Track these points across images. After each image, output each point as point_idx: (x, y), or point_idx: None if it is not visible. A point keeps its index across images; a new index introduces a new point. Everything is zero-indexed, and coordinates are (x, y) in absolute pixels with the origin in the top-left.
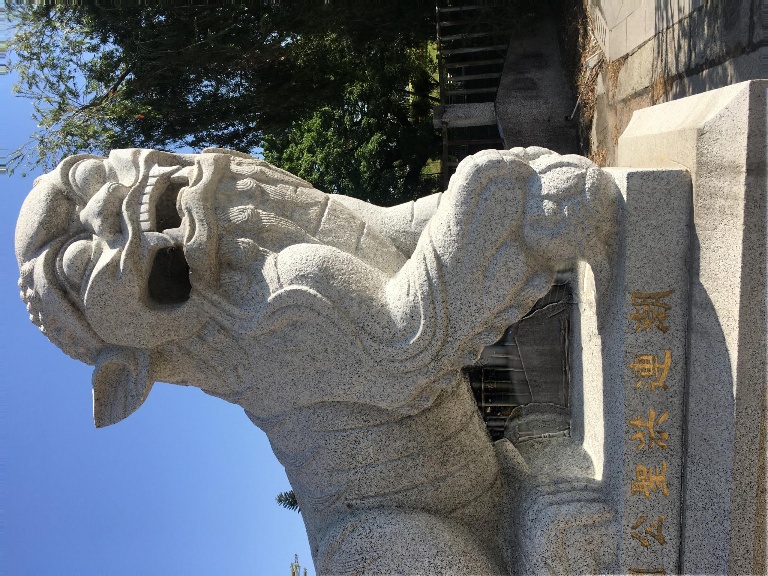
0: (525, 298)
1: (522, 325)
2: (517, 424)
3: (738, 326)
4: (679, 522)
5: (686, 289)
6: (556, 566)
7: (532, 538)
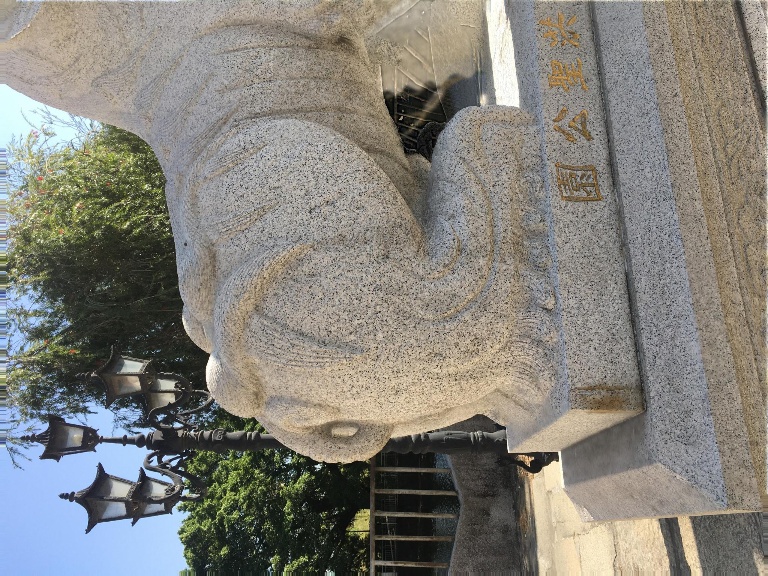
0: None
1: (434, 8)
2: (431, 139)
3: None
4: (603, 117)
5: None
6: (473, 159)
7: (445, 139)
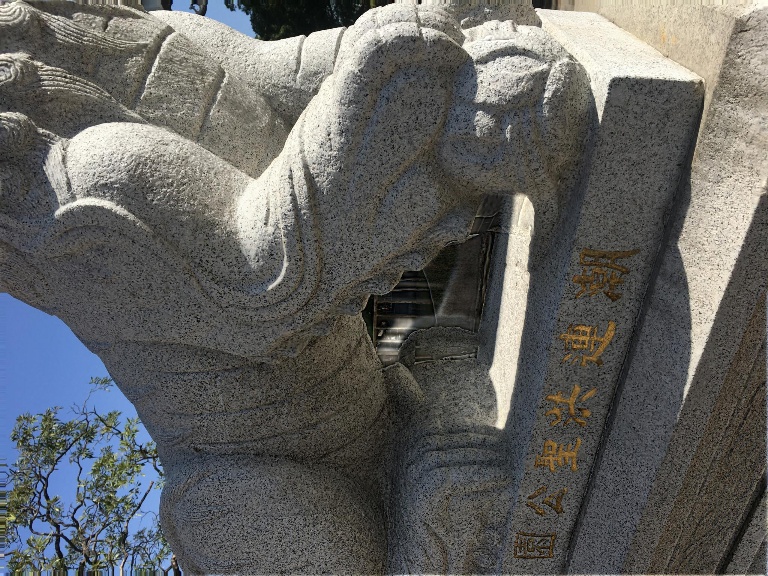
0: (434, 241)
1: None
2: (414, 349)
3: (714, 319)
4: (582, 495)
5: (655, 250)
6: (436, 528)
7: (413, 498)
